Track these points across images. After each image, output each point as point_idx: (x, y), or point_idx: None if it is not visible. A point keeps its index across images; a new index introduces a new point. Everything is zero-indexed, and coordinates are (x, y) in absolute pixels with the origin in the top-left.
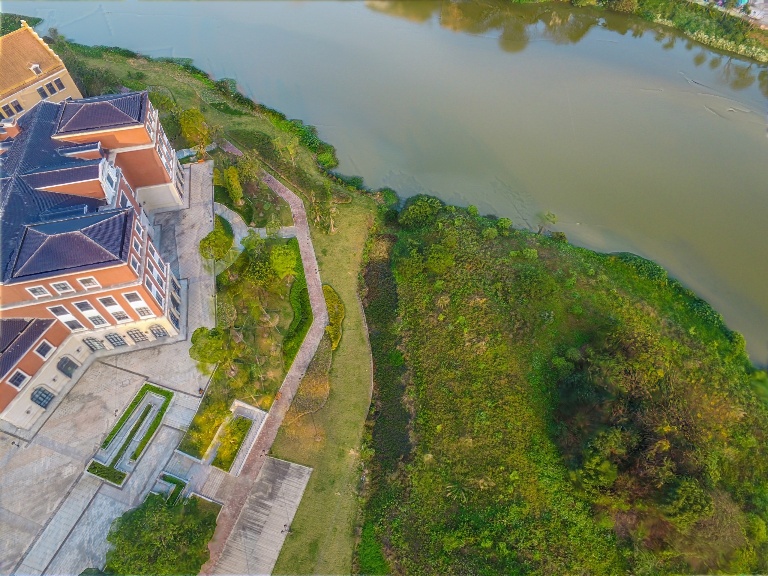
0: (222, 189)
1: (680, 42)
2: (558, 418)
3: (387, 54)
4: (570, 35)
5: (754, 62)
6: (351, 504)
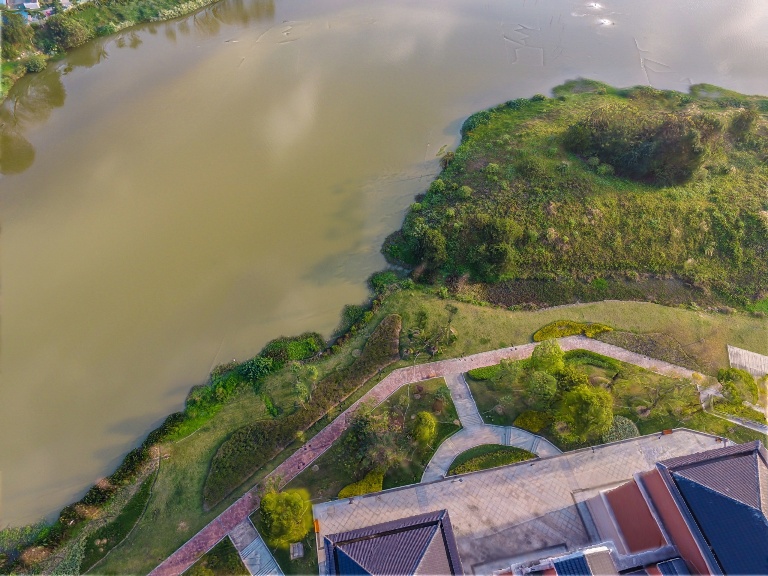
0: (391, 475)
1: (144, 33)
2: (641, 182)
3: (46, 266)
4: (53, 104)
5: (207, 7)
6: (740, 318)
